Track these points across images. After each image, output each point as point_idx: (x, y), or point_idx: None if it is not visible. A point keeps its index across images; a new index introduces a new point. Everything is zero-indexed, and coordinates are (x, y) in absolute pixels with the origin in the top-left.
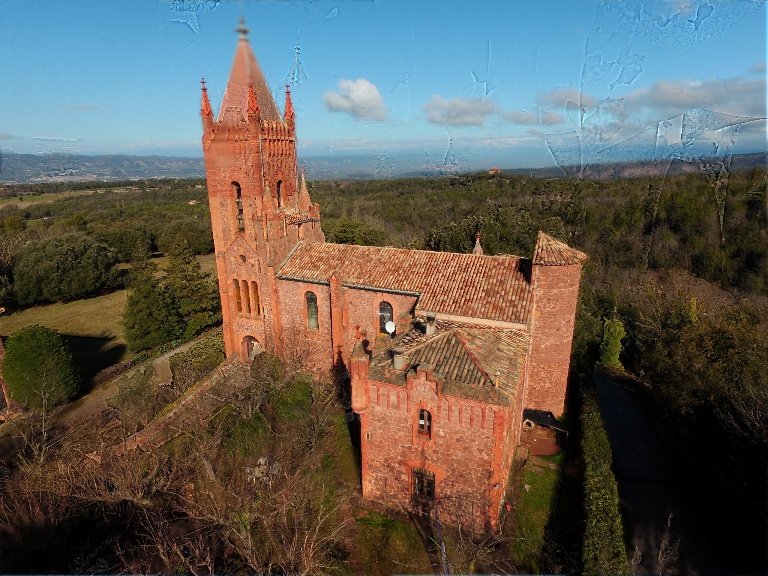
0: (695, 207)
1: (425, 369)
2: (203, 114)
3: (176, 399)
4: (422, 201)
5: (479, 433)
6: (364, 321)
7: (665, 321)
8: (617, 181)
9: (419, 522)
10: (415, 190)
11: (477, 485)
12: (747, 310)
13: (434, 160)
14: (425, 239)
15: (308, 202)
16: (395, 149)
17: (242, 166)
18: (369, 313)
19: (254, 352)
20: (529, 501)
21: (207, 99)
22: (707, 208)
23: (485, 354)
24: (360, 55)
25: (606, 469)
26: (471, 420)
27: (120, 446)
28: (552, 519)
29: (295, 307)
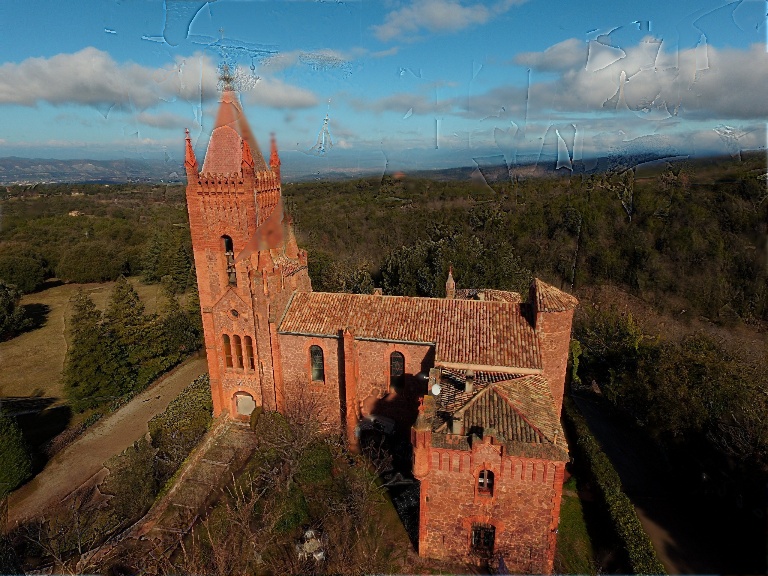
0: (613, 227)
1: (491, 434)
2: (187, 165)
3: (175, 472)
4: (356, 219)
5: (540, 486)
6: (374, 371)
7: (606, 334)
8: (540, 200)
9: (480, 572)
10: (350, 208)
11: (536, 532)
12: (706, 339)
13: (367, 178)
14: (374, 262)
15: (296, 249)
16: (330, 169)
17: (234, 220)
18: (380, 363)
19: (241, 405)
20: (564, 533)
21: (191, 150)
22: (623, 228)
23: (526, 408)
24: (377, 121)
25: (619, 492)
26: (533, 476)
27: (126, 537)
28: (589, 547)
29: (298, 361)
